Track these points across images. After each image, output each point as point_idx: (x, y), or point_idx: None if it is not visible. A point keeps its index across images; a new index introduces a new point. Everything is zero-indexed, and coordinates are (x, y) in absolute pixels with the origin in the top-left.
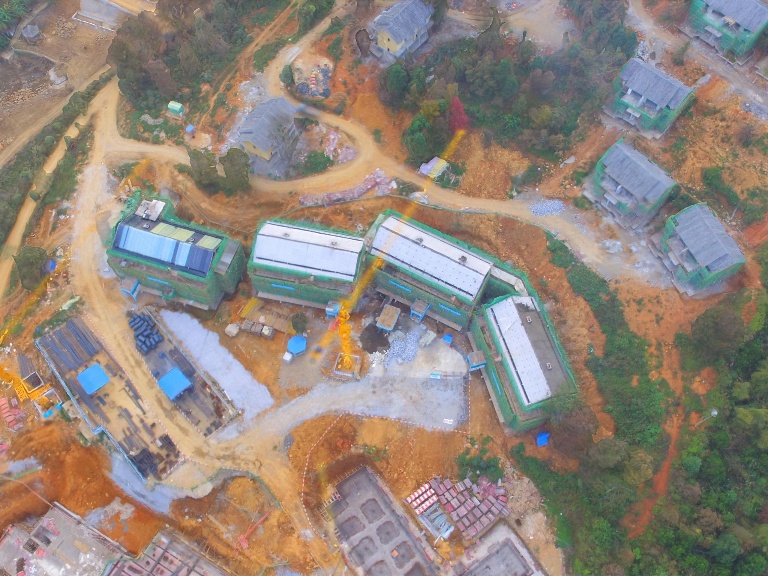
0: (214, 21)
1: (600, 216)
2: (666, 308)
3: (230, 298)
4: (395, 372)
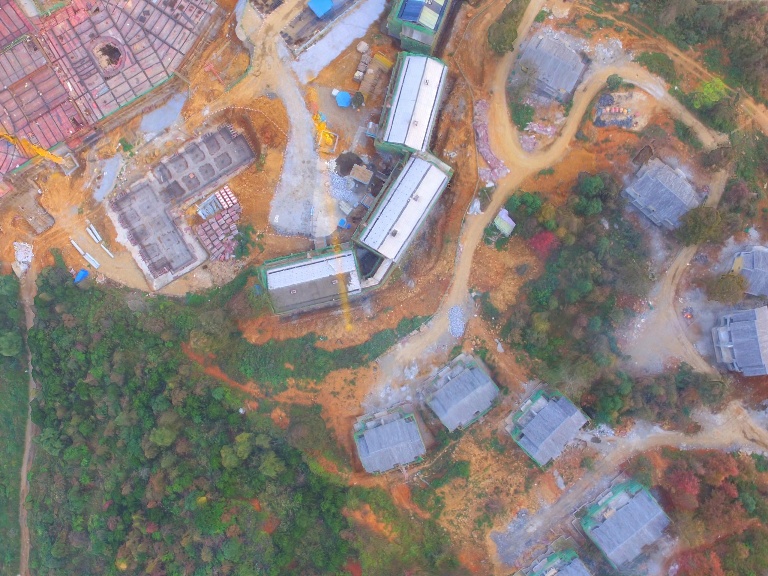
0: (704, 7)
1: (440, 366)
2: (343, 401)
3: (397, 45)
4: (320, 179)
